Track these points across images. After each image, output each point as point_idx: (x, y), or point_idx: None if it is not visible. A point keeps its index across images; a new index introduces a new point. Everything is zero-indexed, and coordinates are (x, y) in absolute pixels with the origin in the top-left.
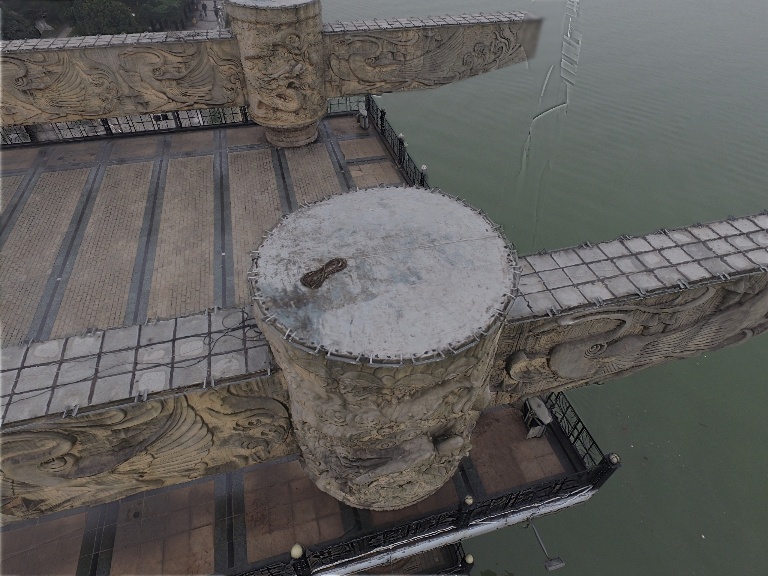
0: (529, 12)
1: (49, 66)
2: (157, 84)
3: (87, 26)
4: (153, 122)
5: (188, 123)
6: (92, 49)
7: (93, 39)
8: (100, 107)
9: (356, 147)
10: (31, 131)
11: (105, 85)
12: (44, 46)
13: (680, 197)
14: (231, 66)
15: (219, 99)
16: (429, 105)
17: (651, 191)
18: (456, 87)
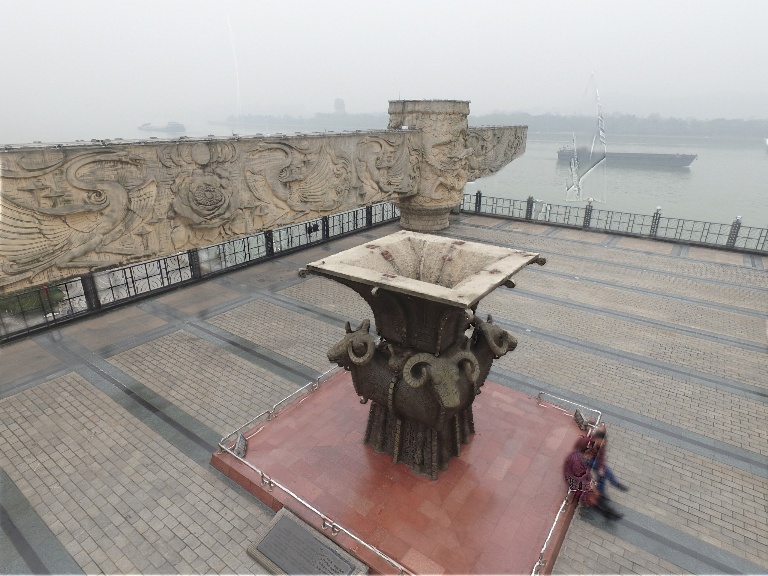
0: (579, 105)
1: (308, 155)
2: (376, 173)
3: None
4: (307, 235)
5: (332, 232)
6: (342, 137)
7: None
8: (334, 201)
9: (479, 221)
10: (196, 262)
11: (343, 175)
12: None
13: (740, 170)
14: (416, 156)
15: (405, 188)
16: (497, 186)
17: (710, 179)
18: (502, 173)
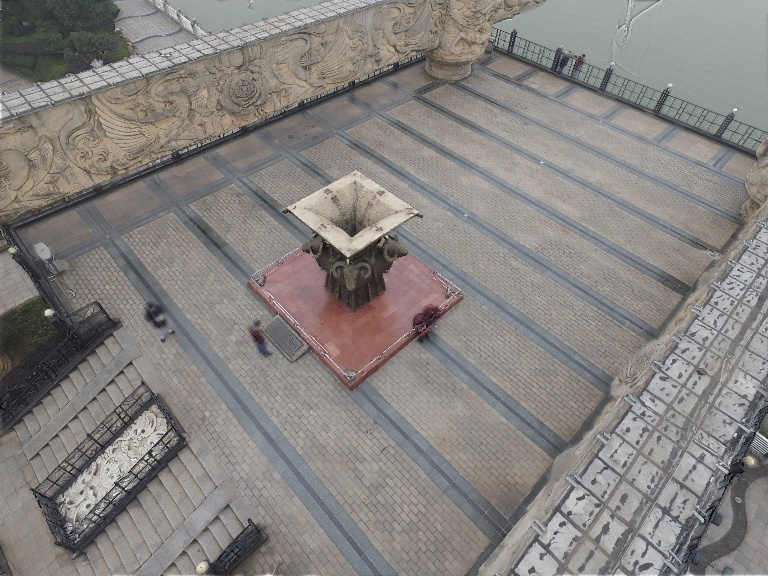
0: None
1: (326, 36)
2: (393, 38)
3: (57, 7)
4: None
5: (358, 79)
6: (359, 12)
7: (344, 2)
8: (350, 71)
9: (504, 67)
10: None
11: (359, 47)
12: (321, 16)
13: None
14: (440, 10)
15: (425, 44)
16: (540, 20)
17: (762, 43)
18: (552, 1)
